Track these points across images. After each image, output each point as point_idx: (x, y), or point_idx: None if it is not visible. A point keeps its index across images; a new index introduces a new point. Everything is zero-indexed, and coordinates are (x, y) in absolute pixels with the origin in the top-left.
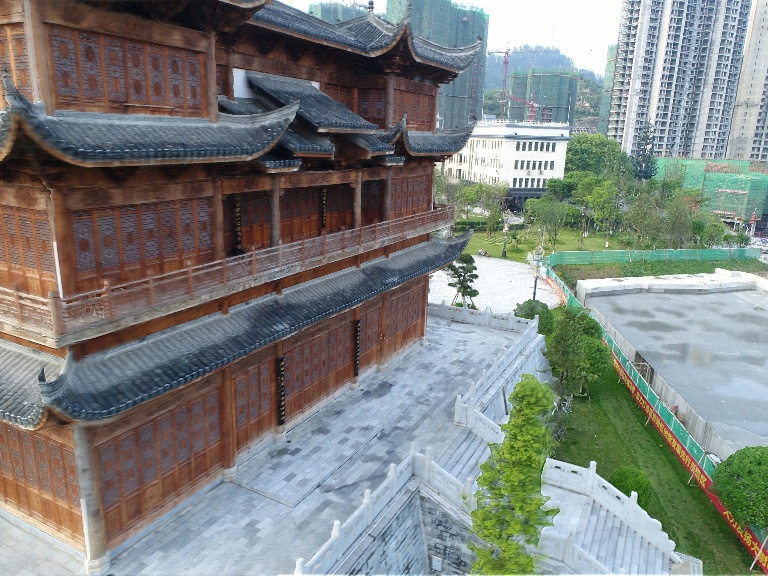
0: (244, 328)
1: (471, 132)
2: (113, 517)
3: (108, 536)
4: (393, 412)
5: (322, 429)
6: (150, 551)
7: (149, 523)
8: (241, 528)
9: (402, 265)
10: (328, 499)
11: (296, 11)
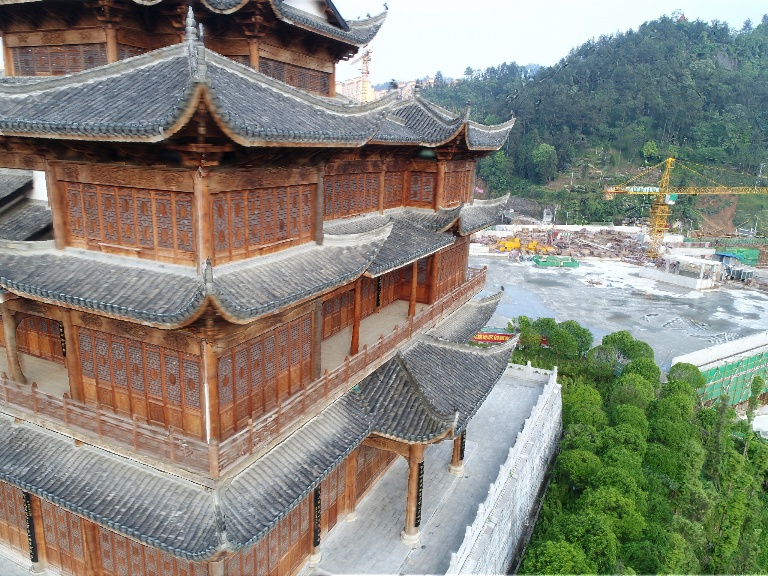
0: None
1: None
2: None
3: None
4: None
5: None
6: None
7: None
8: None
9: None
10: None
11: None
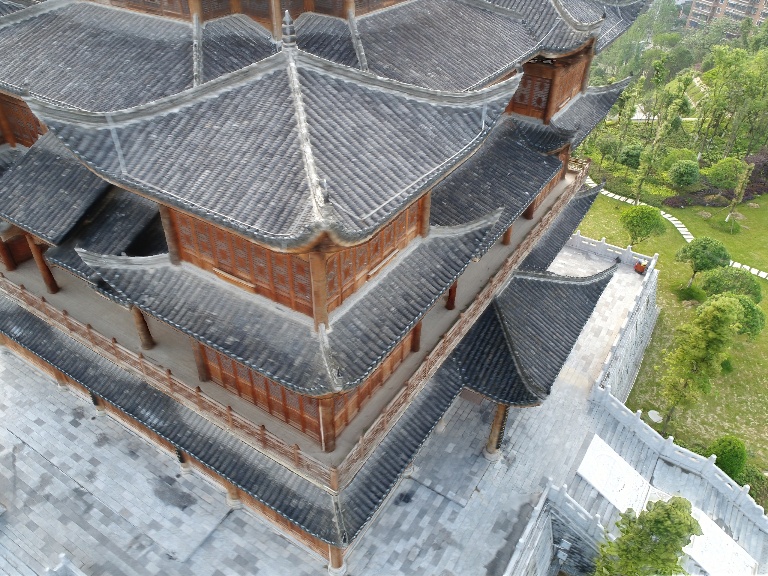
0: (6, 309)
1: (330, 387)
2: (5, 336)
3: (5, 341)
4: (115, 503)
5: (105, 441)
6: (7, 366)
7: (23, 358)
8: (2, 402)
9: (202, 428)
10: (4, 449)
11: None
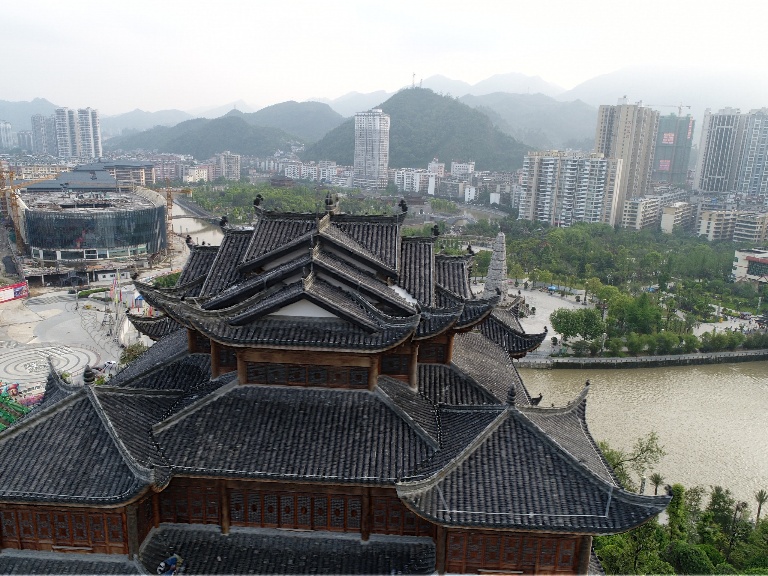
0: None
1: None
2: None
3: None
4: None
5: None
6: None
7: None
8: None
9: None
10: None
11: (167, 360)
